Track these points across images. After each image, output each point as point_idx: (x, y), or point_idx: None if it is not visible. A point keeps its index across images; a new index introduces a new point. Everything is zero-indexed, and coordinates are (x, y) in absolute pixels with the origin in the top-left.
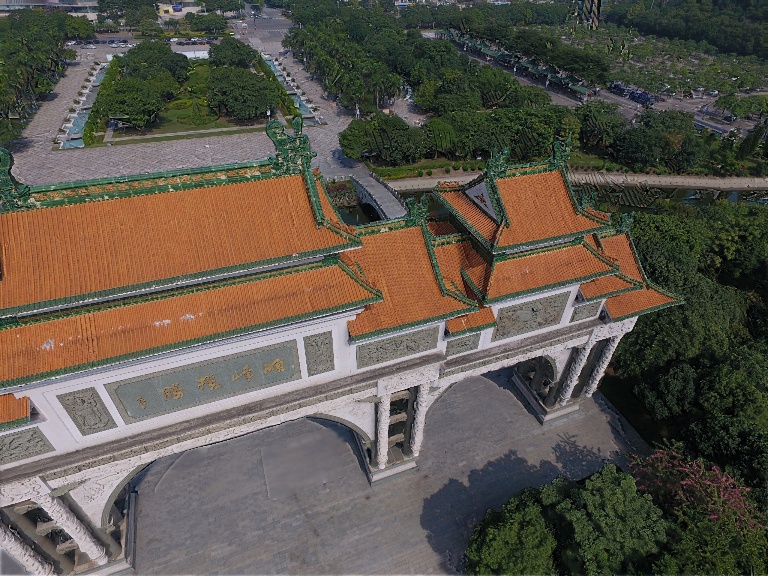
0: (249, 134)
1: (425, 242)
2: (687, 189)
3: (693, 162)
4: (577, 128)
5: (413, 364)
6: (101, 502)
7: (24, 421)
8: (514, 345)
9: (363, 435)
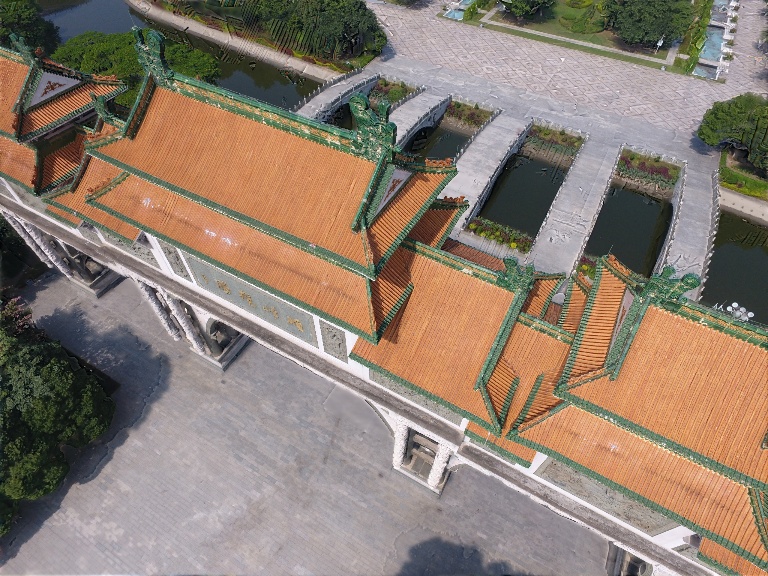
0: (617, 61)
1: (505, 316)
2: None
3: None
4: None
5: (423, 420)
6: (205, 318)
7: (130, 242)
8: (563, 502)
9: (390, 429)
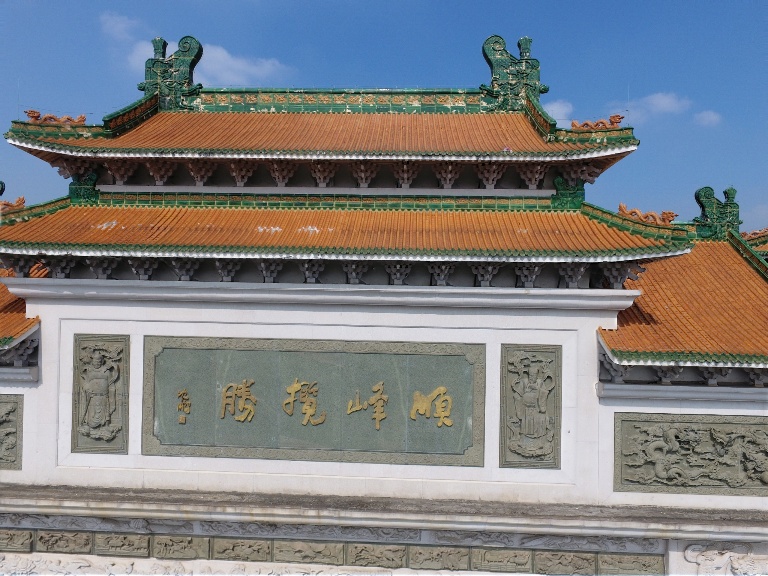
0: None
1: (745, 257)
2: None
3: None
4: None
5: None
6: None
7: (3, 341)
8: None
9: None
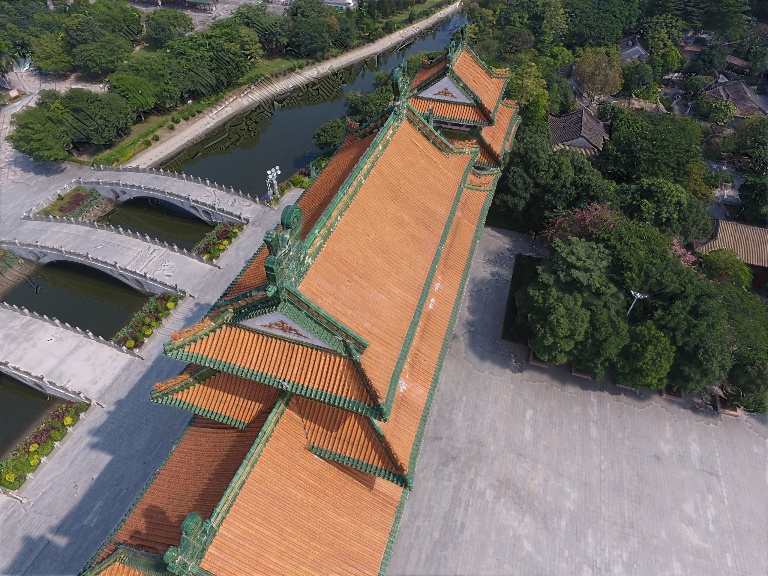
0: None
1: None
2: (360, 61)
3: (352, 37)
4: (256, 37)
5: None
6: None
7: None
8: None
9: None
